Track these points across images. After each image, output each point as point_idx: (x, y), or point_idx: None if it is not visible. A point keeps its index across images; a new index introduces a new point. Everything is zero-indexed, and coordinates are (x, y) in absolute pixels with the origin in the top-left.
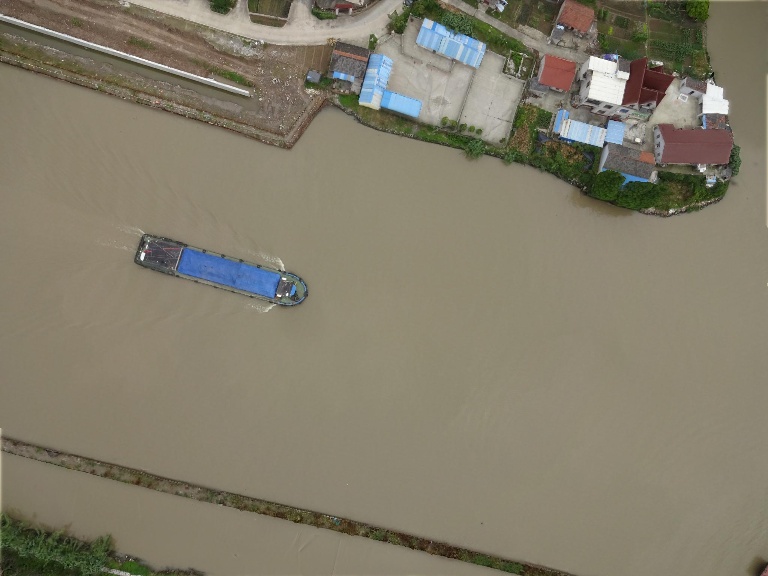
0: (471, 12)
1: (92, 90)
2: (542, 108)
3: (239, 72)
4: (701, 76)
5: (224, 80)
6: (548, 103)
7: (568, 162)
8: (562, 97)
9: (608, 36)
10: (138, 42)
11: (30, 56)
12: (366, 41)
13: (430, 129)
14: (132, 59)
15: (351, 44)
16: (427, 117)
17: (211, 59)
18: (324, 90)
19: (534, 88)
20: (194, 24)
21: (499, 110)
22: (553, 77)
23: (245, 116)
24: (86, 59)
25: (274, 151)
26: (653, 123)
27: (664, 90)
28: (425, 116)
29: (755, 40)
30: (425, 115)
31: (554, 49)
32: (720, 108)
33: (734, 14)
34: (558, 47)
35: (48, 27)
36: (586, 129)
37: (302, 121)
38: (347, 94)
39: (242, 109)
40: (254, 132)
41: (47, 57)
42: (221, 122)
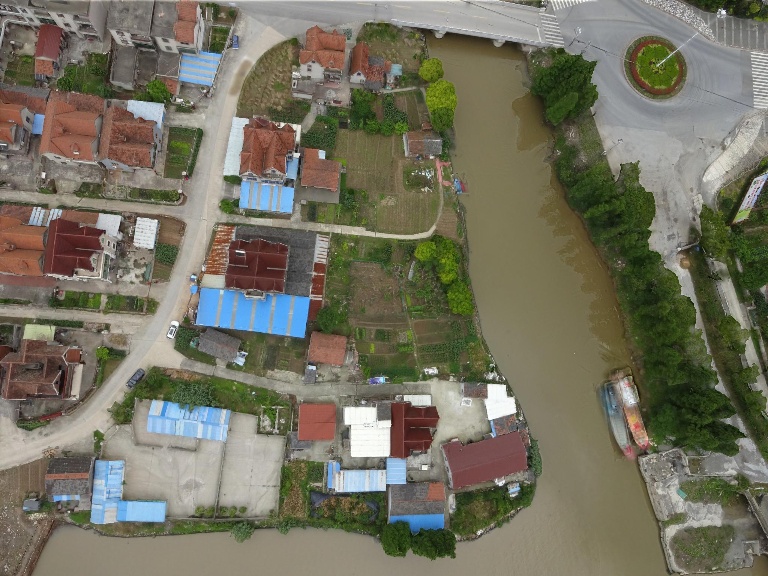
0: (209, 371)
1: None
2: (311, 460)
3: None
4: (482, 370)
5: None
6: (317, 452)
7: (352, 513)
8: (331, 441)
9: (371, 355)
10: None
11: None
12: (90, 440)
13: (185, 523)
14: None
15: (72, 450)
16: (179, 508)
17: None
18: (49, 513)
19: (295, 446)
20: None
21: (262, 476)
22: (312, 431)
23: None
24: None
25: None
26: (439, 440)
27: (434, 426)
28: (177, 508)
29: (541, 289)
30: (177, 506)
31: (312, 388)
32: (507, 409)
33: (511, 274)
34: (316, 384)
35: None
36: (363, 476)
37: (29, 557)
38: (77, 512)
39: None
40: None
41: None
42: None
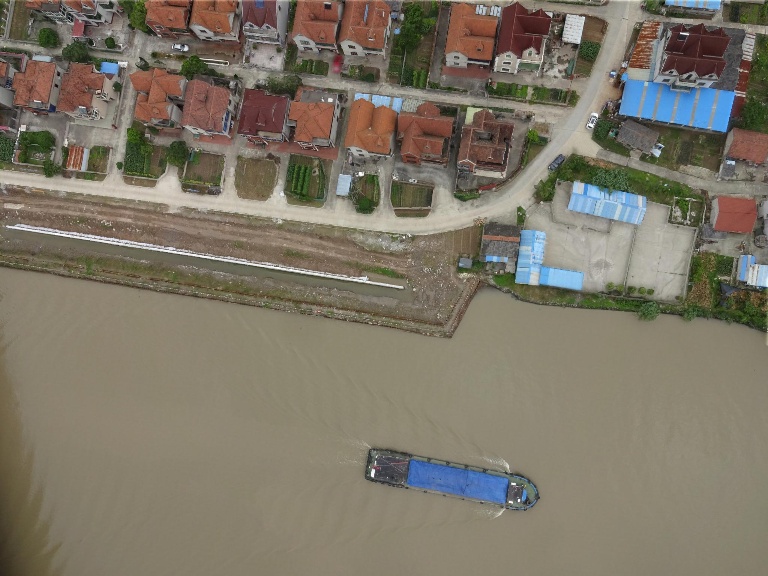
0: (623, 162)
1: (259, 308)
2: (720, 254)
3: (390, 267)
4: None
5: (377, 275)
6: (727, 247)
7: (760, 310)
8: (743, 238)
9: None
10: (294, 254)
11: (203, 284)
12: (514, 215)
13: (595, 297)
14: (290, 271)
15: (499, 221)
16: (590, 284)
17: (362, 259)
18: (477, 273)
19: (709, 236)
20: (343, 229)
21: (670, 264)
22: (730, 222)
23: (402, 309)
24: (250, 277)
25: (435, 342)
26: None
27: None
28: (587, 283)
29: None
30: (587, 282)
31: (725, 185)
32: None
33: None
34: (730, 182)
35: (214, 253)
36: None
37: (459, 308)
38: (502, 274)
39: (398, 302)
40: (413, 327)
41: (217, 282)
42: (380, 321)
